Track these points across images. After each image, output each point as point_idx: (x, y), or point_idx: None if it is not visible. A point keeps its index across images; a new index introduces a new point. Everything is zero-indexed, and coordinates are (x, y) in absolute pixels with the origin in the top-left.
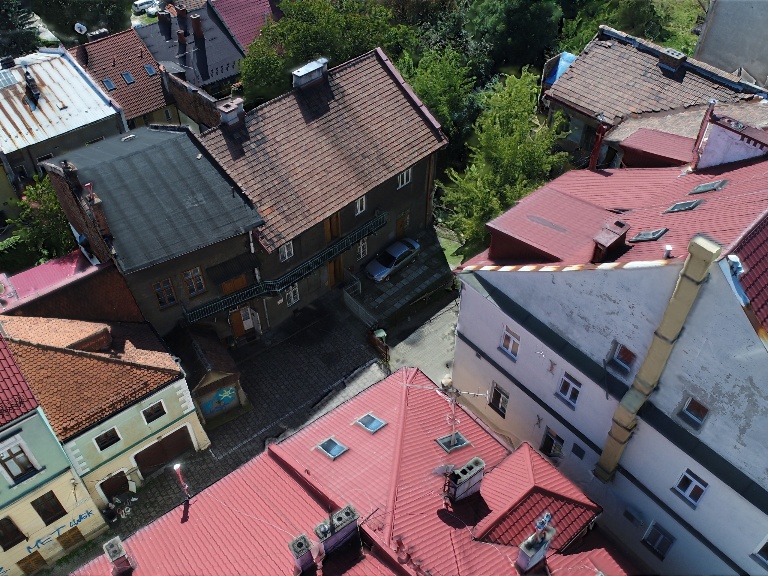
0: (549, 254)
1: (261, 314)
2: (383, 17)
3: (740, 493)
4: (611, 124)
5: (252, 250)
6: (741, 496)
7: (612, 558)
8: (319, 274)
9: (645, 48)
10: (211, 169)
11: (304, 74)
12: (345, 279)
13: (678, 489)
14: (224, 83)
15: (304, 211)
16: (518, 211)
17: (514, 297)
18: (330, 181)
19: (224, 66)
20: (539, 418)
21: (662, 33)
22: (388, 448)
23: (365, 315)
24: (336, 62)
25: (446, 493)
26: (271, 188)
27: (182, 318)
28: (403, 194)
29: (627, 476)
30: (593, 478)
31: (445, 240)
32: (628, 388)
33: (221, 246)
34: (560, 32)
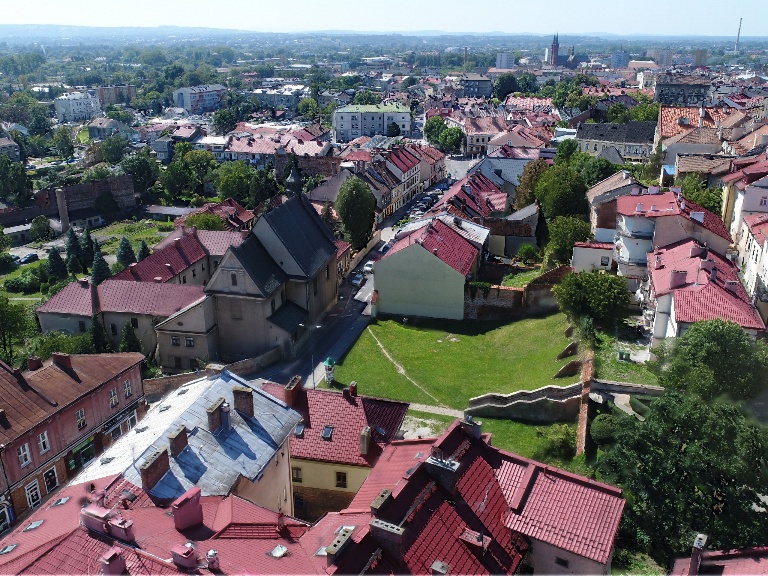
0: None
1: None
2: None
3: None
4: (708, 172)
5: None
6: None
7: None
8: None
9: (696, 155)
10: None
11: None
12: None
13: None
14: None
15: None
16: None
17: (766, 185)
18: None
19: None
20: None
21: None
22: None
23: None
24: None
25: None
26: None
27: None
28: None
29: None
30: None
31: None
32: None
33: None
34: None
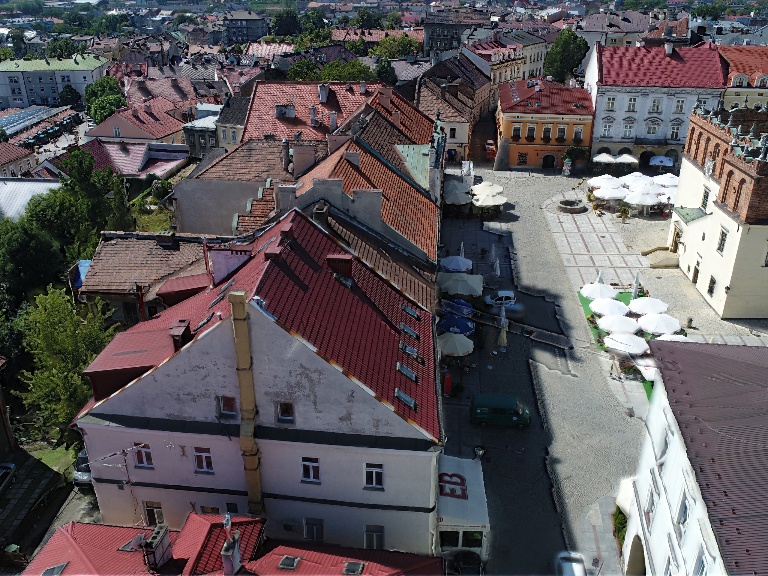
0: (143, 367)
1: None
2: None
3: (335, 444)
4: (143, 293)
5: None
6: (337, 447)
7: (288, 547)
8: None
9: (142, 237)
10: None
11: None
12: None
13: (305, 479)
14: None
15: None
16: (104, 355)
17: (131, 413)
18: None
19: None
20: (192, 504)
21: None
22: (80, 571)
23: None
24: None
25: (148, 568)
26: None
27: None
28: None
29: (272, 497)
30: (251, 516)
31: (37, 452)
32: None
33: None
34: None
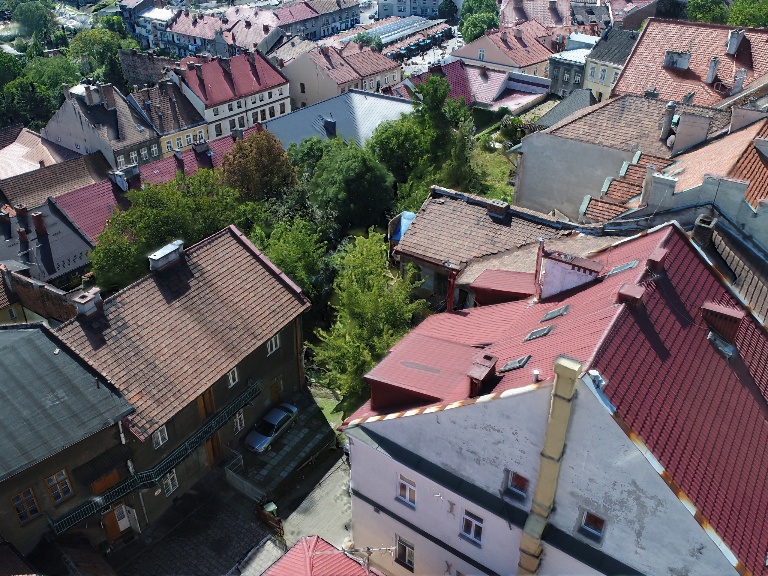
0: (429, 396)
1: (138, 510)
2: (231, 197)
3: None
4: (458, 269)
5: (123, 441)
6: None
7: None
8: (197, 455)
9: (473, 201)
10: (71, 363)
11: (161, 257)
12: (225, 456)
13: None
14: (72, 275)
15: (175, 392)
16: (392, 359)
17: (403, 443)
18: (199, 357)
19: (71, 258)
20: (448, 564)
21: (482, 187)
22: None
23: (251, 490)
24: (190, 242)
25: None
26: (138, 373)
27: (47, 531)
28: (274, 360)
29: None
30: None
31: (321, 399)
32: (527, 514)
33: (88, 442)
34: (395, 195)
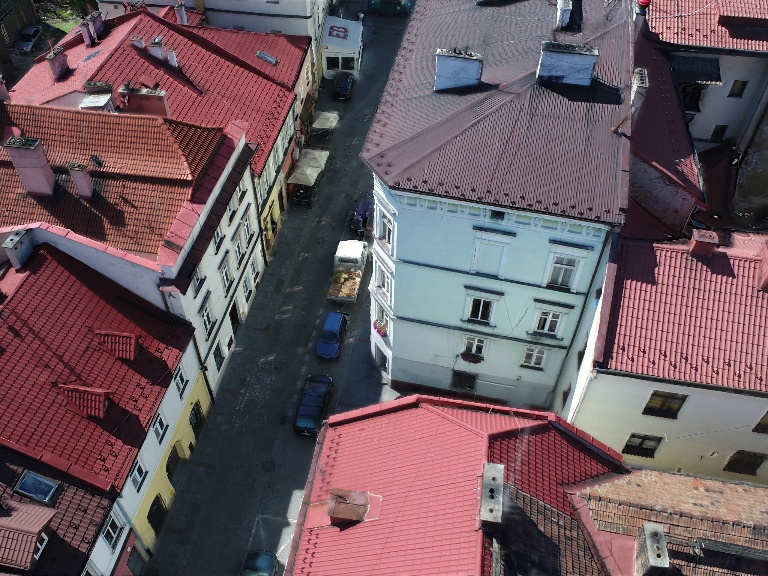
0: None
1: None
2: None
3: None
4: None
5: None
6: None
7: None
8: None
9: None
10: None
11: None
12: (5, 57)
13: None
14: None
15: None
16: None
17: None
18: None
19: None
20: None
21: None
22: None
23: None
24: None
25: None
26: None
27: None
28: None
29: (211, 10)
30: None
31: (56, 24)
32: None
33: None
34: None
